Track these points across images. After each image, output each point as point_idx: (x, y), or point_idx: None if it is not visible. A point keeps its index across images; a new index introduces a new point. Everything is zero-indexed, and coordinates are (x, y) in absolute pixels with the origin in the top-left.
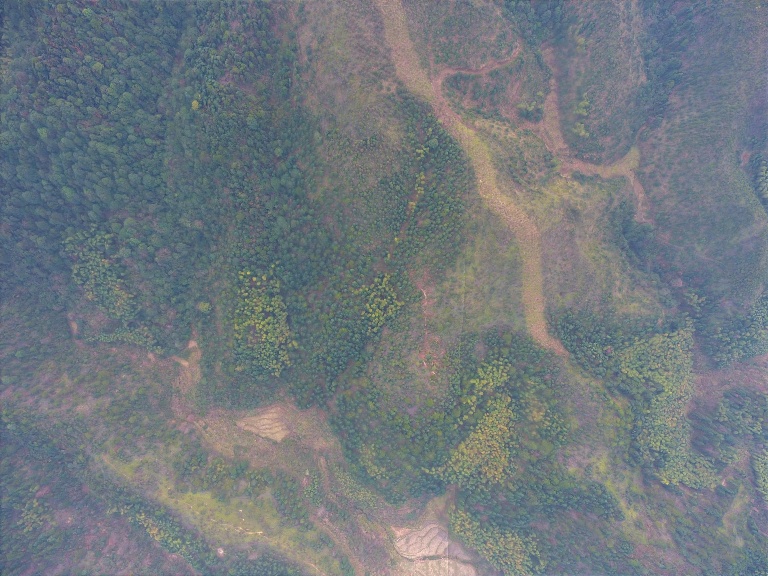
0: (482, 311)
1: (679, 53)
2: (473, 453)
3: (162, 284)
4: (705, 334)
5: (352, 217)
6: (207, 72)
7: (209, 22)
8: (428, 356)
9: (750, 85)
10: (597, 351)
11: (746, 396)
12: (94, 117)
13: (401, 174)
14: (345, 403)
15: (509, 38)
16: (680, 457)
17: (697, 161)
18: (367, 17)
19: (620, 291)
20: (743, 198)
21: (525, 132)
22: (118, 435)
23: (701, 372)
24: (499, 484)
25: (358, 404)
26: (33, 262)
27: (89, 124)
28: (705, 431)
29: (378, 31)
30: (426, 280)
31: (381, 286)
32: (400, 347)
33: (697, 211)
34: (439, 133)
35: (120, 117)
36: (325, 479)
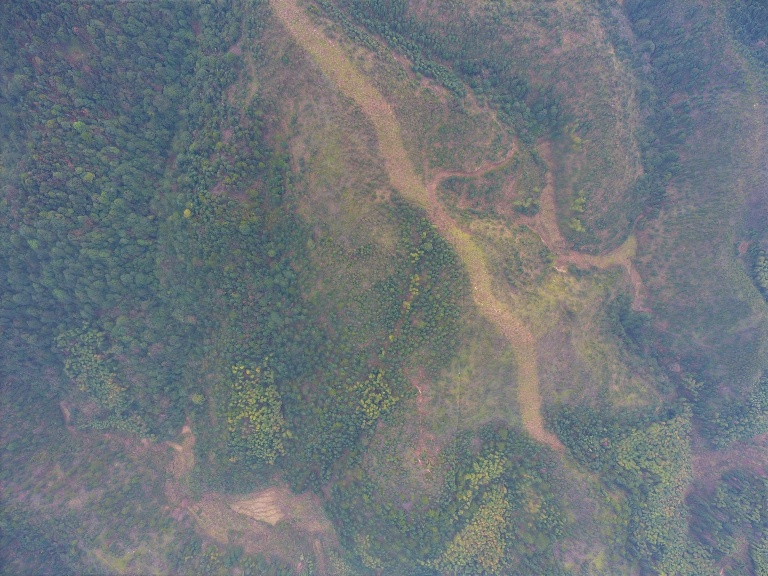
0: (477, 410)
1: (676, 146)
2: (469, 544)
3: (155, 375)
4: (703, 418)
5: (346, 318)
6: (199, 182)
7: (201, 127)
8: (423, 455)
9: (748, 182)
10: (594, 444)
11: (744, 480)
12: (85, 225)
13: (395, 276)
14: (340, 492)
15: (504, 140)
16: (678, 548)
17: (694, 255)
18: (360, 131)
19: (617, 383)
20: (741, 292)
21: (521, 229)
22: (111, 528)
23: (699, 453)
24: (495, 574)
25: (353, 495)
26: (25, 356)
27: (80, 233)
28: (703, 517)
29: (371, 144)
30: (421, 378)
31: (376, 382)
32: (395, 442)
33: (694, 303)
34: (434, 237)
35: (112, 223)
36: (320, 562)
